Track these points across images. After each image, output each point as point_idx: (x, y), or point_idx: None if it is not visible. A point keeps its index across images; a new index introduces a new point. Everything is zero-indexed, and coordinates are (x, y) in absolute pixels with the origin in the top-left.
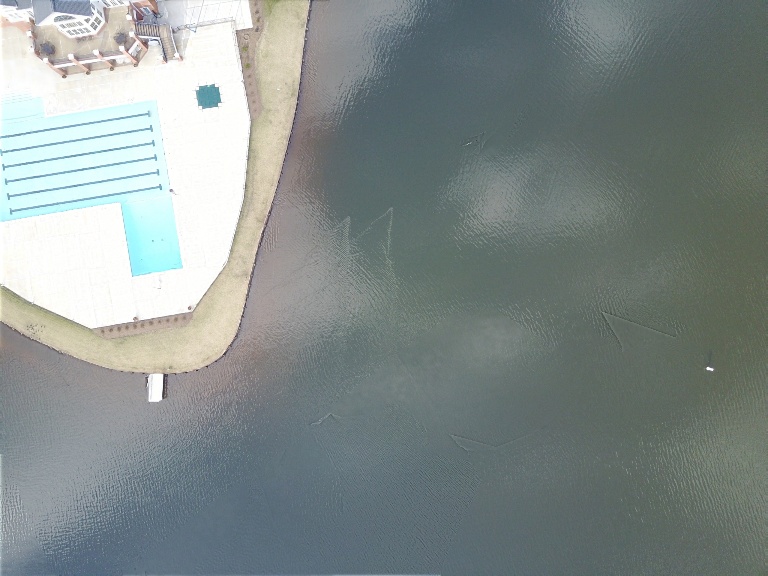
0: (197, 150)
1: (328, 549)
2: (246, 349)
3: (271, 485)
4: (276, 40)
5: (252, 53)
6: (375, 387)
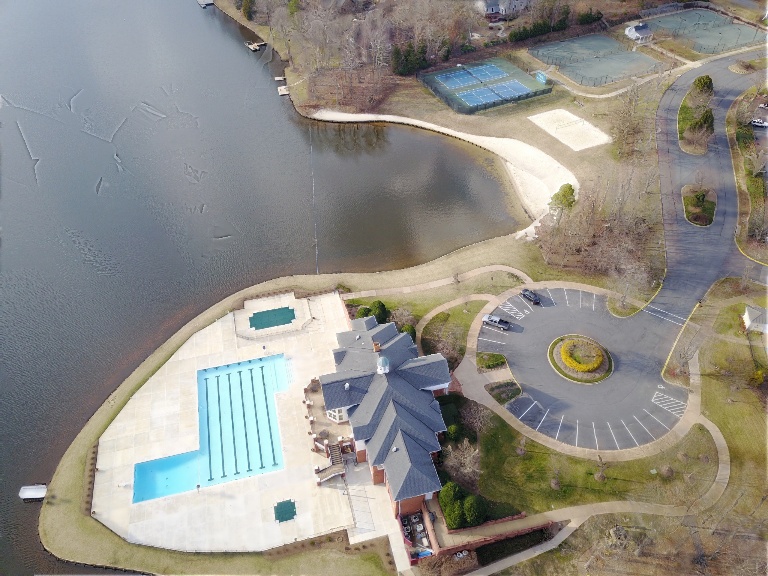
0: (238, 506)
1: None
2: (45, 570)
3: None
4: (339, 568)
5: (325, 546)
6: None
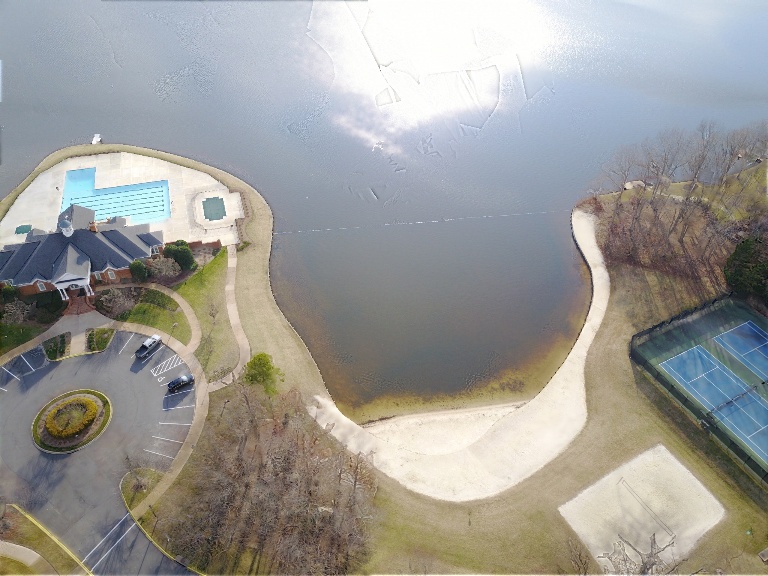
0: (40, 210)
1: (5, 76)
2: None
3: (36, 104)
4: None
5: None
6: None
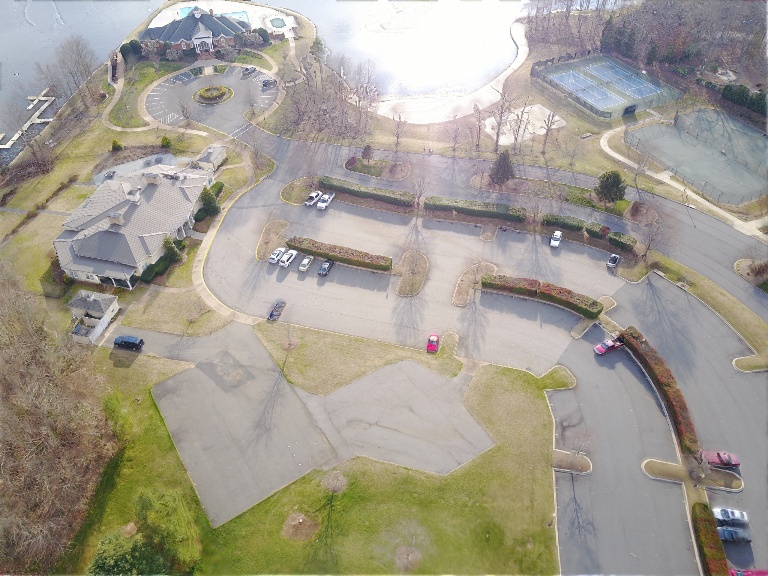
0: None
1: None
2: None
3: None
4: None
5: None
6: (125, 15)
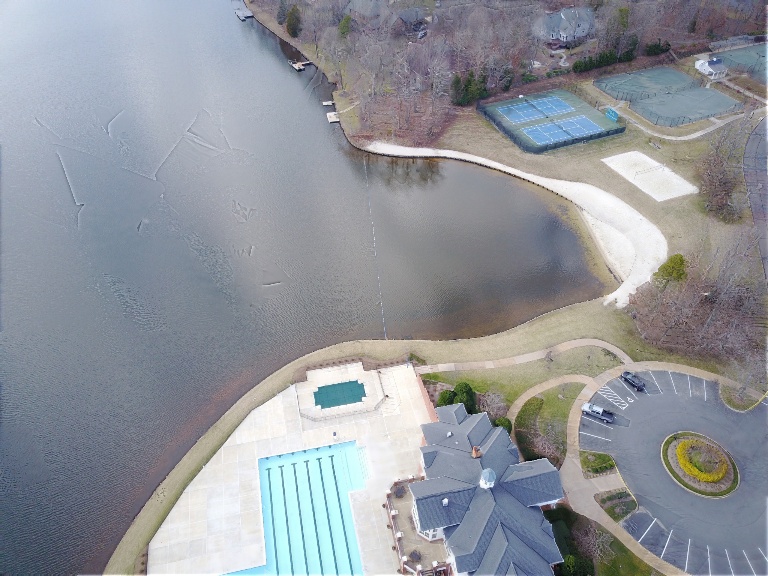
0: None
1: None
2: None
3: None
4: None
5: None
6: None
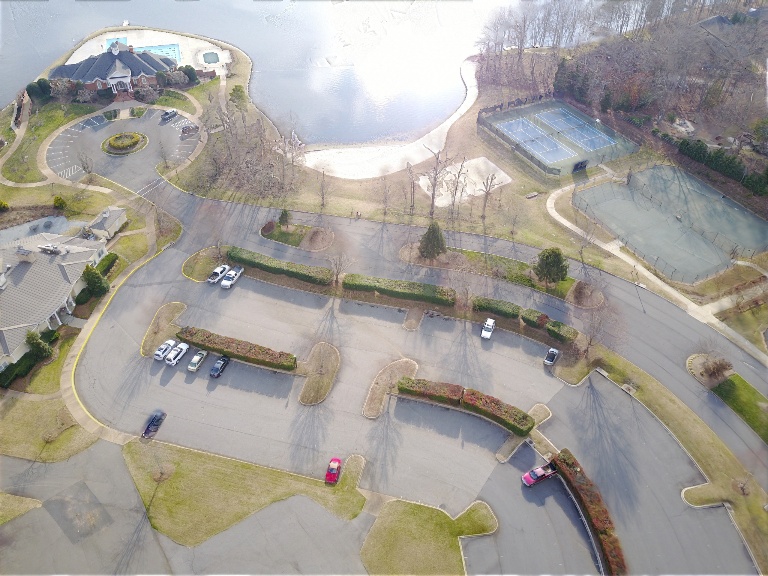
0: None
1: None
2: None
3: None
4: None
5: None
6: (50, 44)
